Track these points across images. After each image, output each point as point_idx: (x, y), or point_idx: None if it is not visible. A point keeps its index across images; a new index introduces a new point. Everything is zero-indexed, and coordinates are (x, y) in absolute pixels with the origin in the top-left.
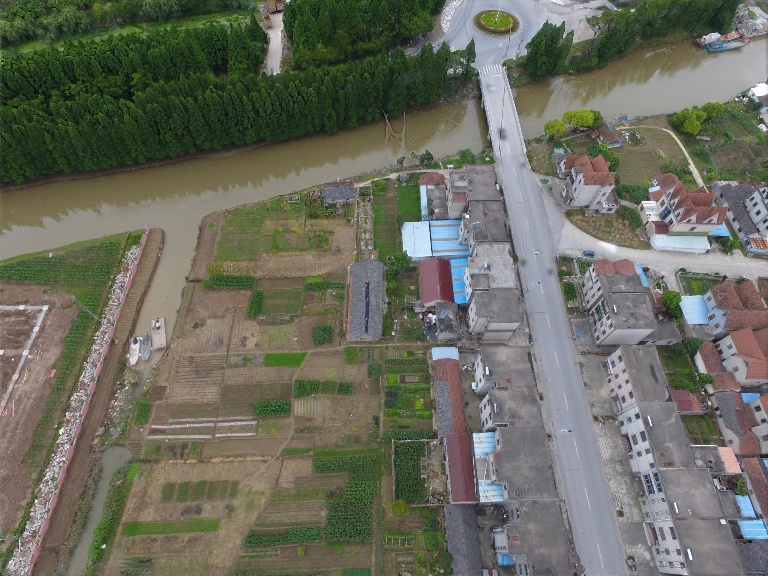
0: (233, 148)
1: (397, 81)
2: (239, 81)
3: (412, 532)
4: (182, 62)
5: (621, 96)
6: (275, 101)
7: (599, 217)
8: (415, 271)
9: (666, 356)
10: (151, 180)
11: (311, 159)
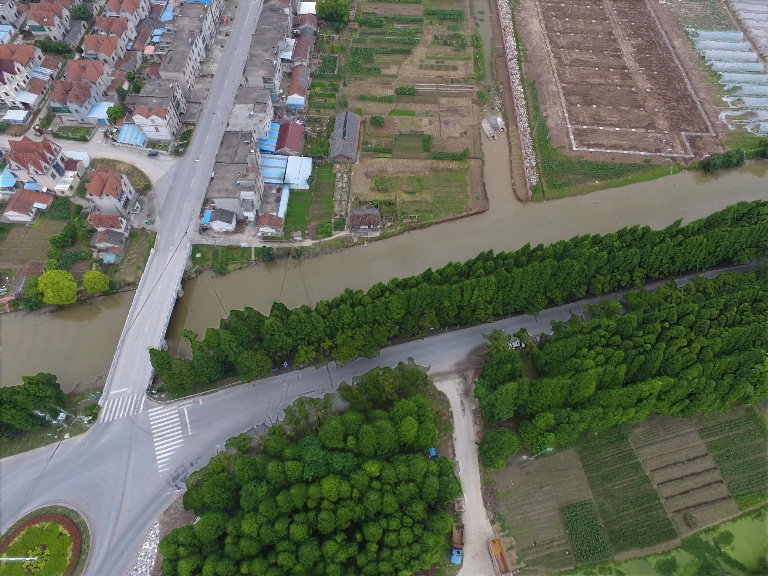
0: None
1: None
2: None
3: None
4: None
5: None
6: None
7: None
8: None
9: None
10: None
11: None
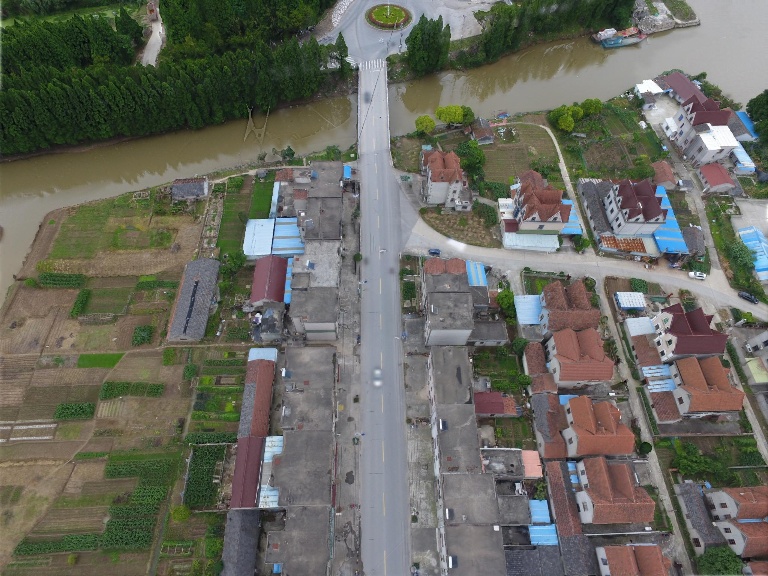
0: (92, 143)
1: (259, 75)
2: (88, 74)
3: (194, 539)
4: (36, 54)
5: (519, 92)
6: (127, 95)
7: (455, 215)
8: (254, 270)
9: (495, 357)
10: (8, 176)
11: (185, 155)
